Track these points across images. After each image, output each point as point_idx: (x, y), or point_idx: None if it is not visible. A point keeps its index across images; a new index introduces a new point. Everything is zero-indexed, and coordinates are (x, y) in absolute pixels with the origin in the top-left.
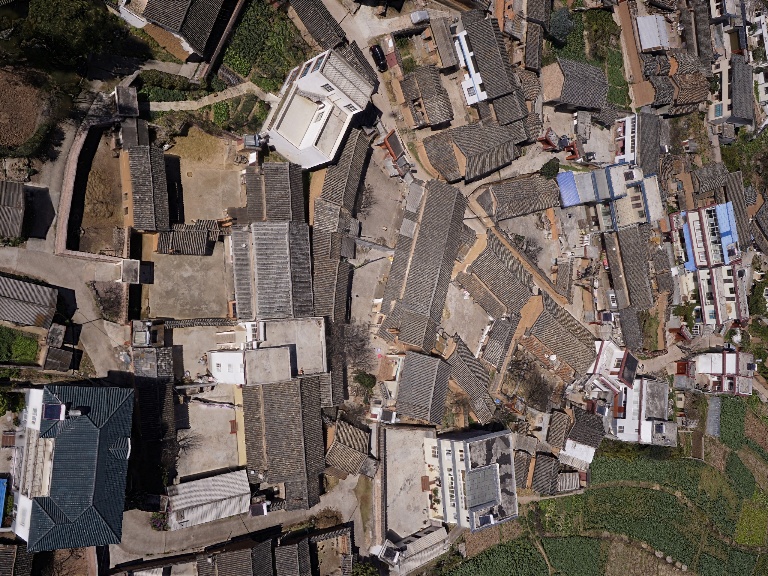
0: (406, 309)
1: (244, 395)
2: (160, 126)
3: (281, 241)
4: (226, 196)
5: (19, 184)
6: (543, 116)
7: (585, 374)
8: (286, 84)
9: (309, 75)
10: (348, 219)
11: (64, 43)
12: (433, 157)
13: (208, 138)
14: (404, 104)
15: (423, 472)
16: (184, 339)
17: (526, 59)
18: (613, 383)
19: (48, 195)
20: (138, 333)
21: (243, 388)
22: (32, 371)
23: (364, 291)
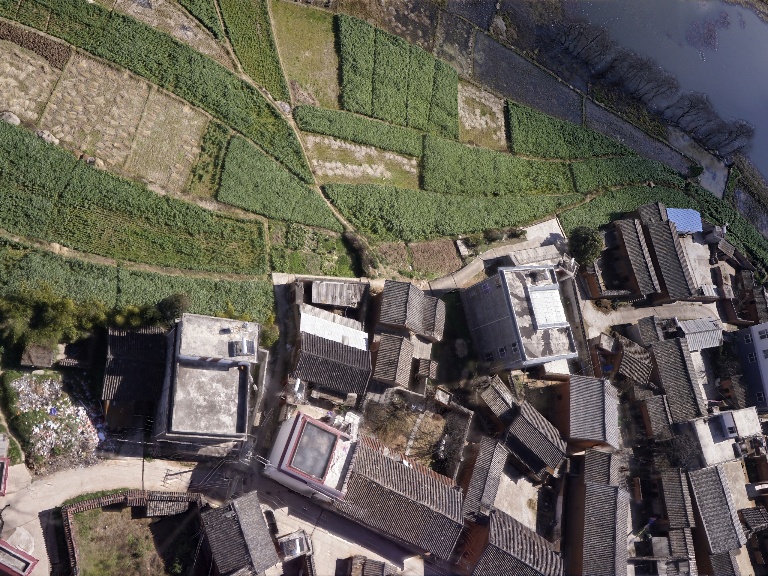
0: None
1: None
2: None
3: (736, 530)
4: None
5: None
6: None
7: None
8: None
9: None
10: (672, 575)
11: None
12: None
13: None
14: None
15: None
16: None
17: None
18: None
19: None
20: None
21: None
22: None
23: None
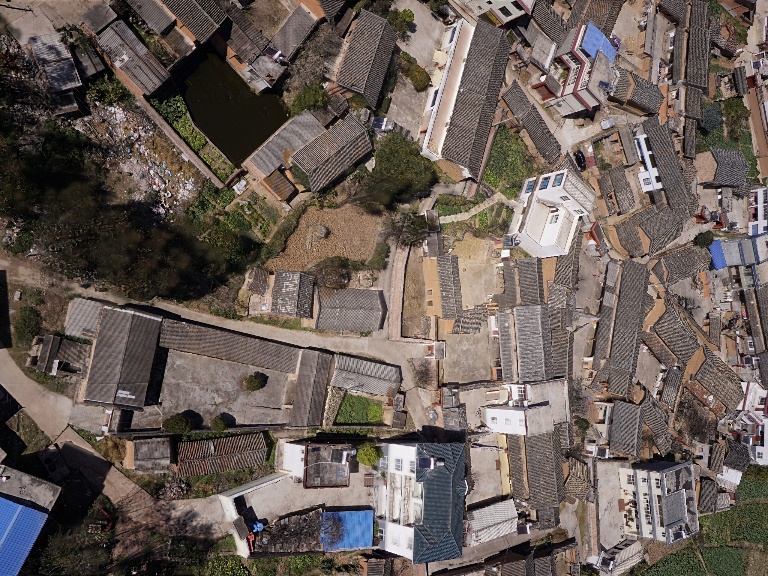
0: (613, 366)
1: (509, 441)
2: (450, 236)
3: (535, 320)
4: (487, 284)
5: (375, 292)
6: (697, 195)
7: (734, 410)
8: (524, 192)
9: (551, 189)
10: (570, 296)
11: (408, 187)
12: (623, 239)
13: (474, 240)
14: (599, 197)
15: (619, 496)
16: (466, 398)
17: (685, 150)
18: (757, 417)
19: (383, 296)
20: (446, 397)
21: (509, 435)
22: (379, 429)
23: (577, 351)
